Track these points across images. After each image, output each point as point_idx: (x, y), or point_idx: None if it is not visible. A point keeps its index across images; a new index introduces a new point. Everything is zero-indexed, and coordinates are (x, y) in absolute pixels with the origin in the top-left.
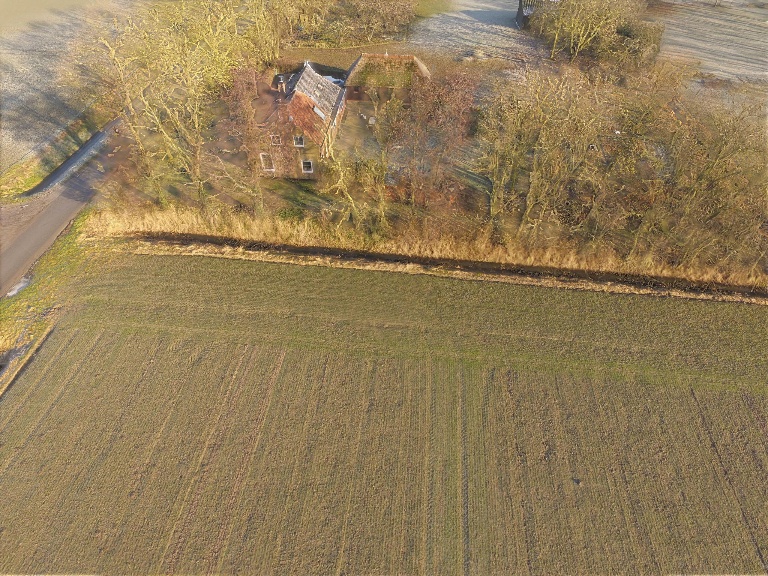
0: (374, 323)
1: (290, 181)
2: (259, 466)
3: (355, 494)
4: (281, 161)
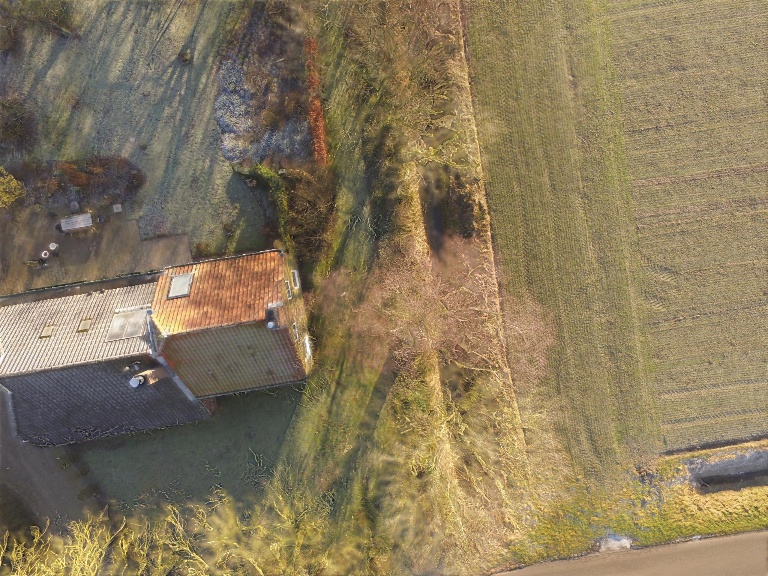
0: (570, 93)
1: (314, 306)
2: (761, 155)
3: (766, 60)
4: (301, 325)
